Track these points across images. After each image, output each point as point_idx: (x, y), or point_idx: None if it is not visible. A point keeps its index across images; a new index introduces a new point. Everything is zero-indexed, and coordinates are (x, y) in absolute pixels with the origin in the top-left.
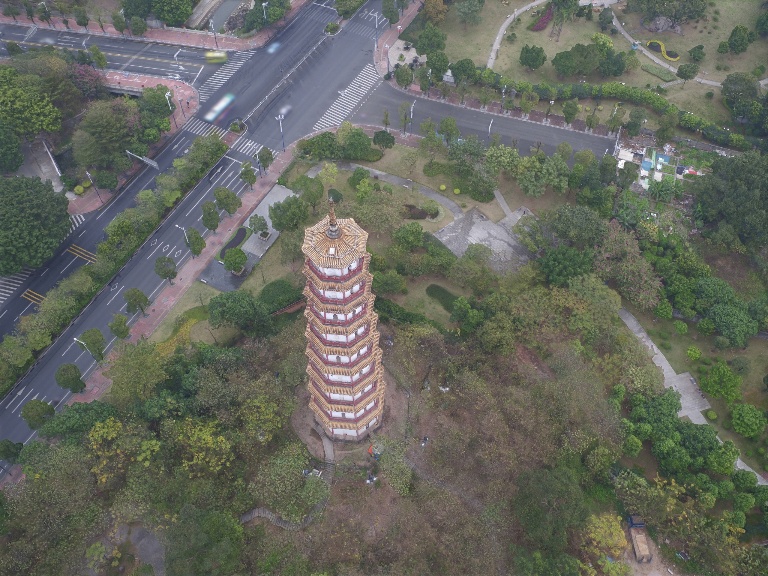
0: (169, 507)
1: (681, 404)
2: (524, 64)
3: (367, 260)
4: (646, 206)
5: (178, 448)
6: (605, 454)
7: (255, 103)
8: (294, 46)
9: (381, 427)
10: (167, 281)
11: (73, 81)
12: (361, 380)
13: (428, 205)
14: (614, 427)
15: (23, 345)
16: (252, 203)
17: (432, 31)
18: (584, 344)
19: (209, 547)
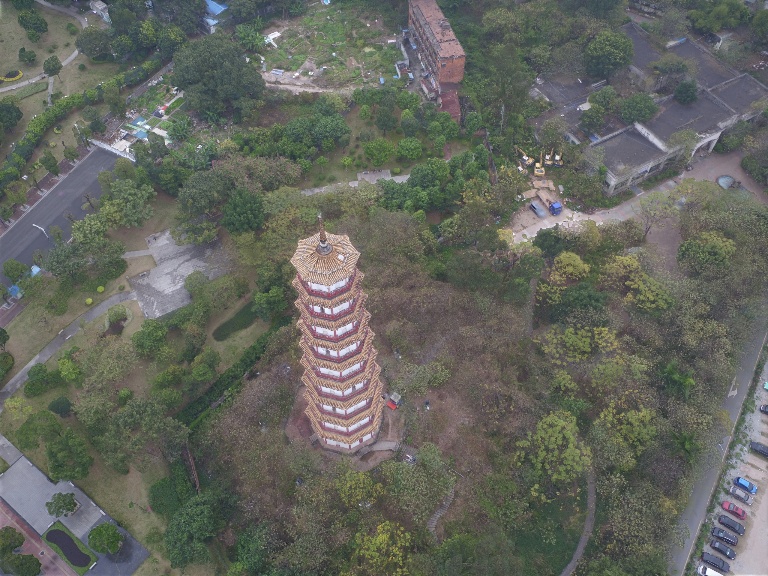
0: None
1: None
2: None
3: None
4: None
5: None
6: None
7: None
8: None
9: None
10: None
11: None
12: None
13: (116, 313)
14: None
15: None
16: (8, 520)
17: None
18: None
19: None
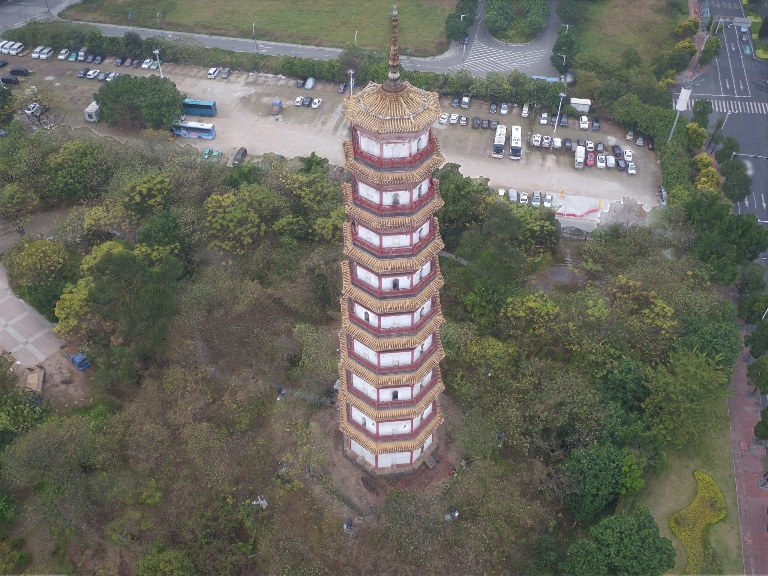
0: None
1: None
2: None
3: (350, 161)
4: None
5: None
6: None
7: None
8: None
9: None
10: None
11: None
12: None
13: None
14: None
15: None
16: None
17: None
18: None
19: None
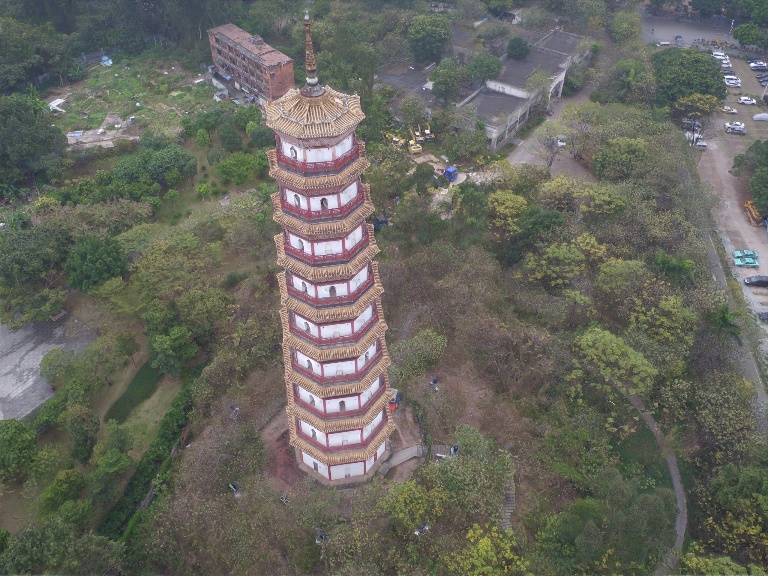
0: None
1: None
2: None
3: None
4: None
5: None
6: None
7: None
8: None
9: None
10: None
11: None
12: None
13: None
14: None
15: None
16: None
17: None
18: None
19: None
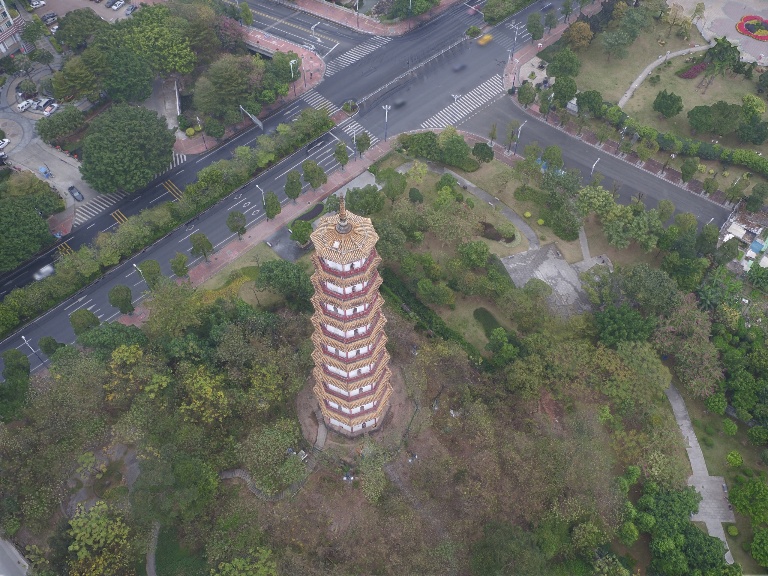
0: (161, 441)
1: (702, 508)
2: (657, 109)
3: (376, 263)
4: (738, 289)
5: (186, 390)
6: (594, 532)
7: (374, 88)
8: (431, 42)
9: (378, 431)
10: (237, 235)
11: (217, 31)
12: (358, 379)
13: (504, 228)
14: (612, 507)
15: (94, 258)
16: (338, 183)
17: (567, 55)
18: (615, 413)
19: (178, 489)
